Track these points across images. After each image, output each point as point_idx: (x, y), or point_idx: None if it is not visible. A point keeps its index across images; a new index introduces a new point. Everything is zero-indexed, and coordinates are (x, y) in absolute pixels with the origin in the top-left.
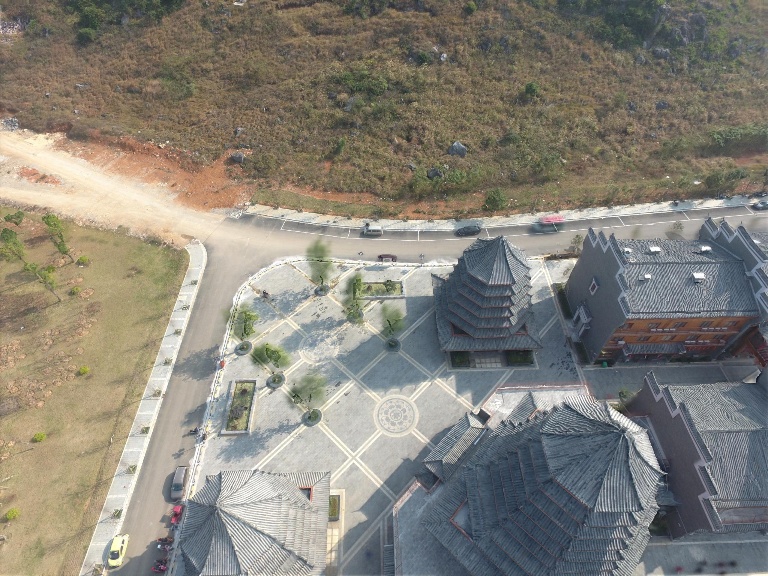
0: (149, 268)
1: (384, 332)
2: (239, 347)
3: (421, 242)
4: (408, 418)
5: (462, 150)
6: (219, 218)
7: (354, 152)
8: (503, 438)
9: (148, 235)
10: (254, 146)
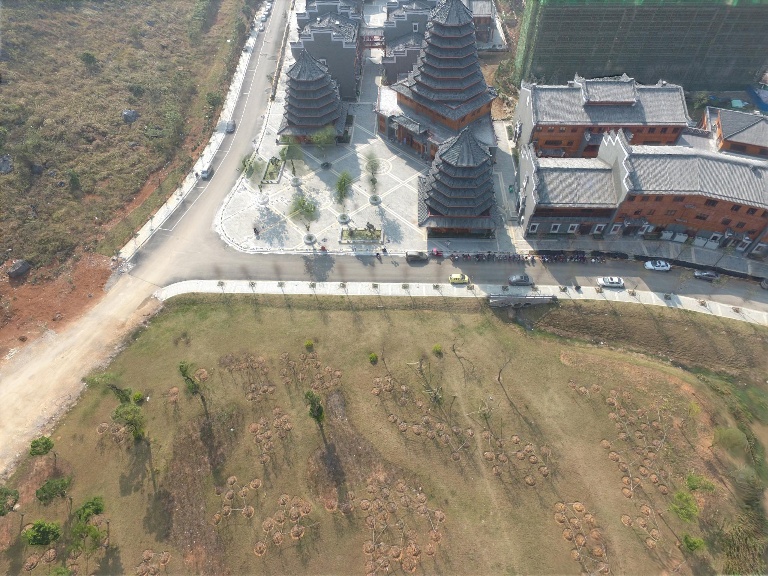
0: (181, 328)
1: (314, 170)
2: (309, 241)
3: (231, 150)
4: (380, 162)
5: (134, 113)
6: (125, 280)
7: (86, 175)
8: (422, 79)
9: (120, 342)
10: (5, 256)
